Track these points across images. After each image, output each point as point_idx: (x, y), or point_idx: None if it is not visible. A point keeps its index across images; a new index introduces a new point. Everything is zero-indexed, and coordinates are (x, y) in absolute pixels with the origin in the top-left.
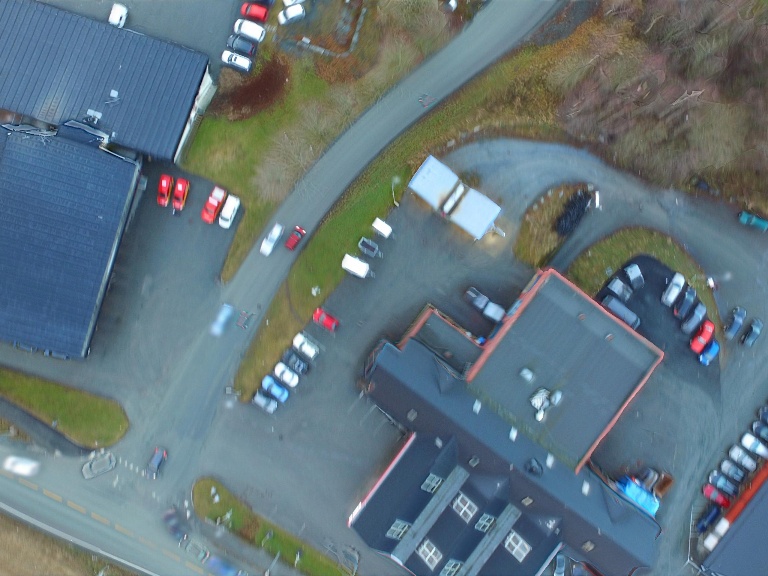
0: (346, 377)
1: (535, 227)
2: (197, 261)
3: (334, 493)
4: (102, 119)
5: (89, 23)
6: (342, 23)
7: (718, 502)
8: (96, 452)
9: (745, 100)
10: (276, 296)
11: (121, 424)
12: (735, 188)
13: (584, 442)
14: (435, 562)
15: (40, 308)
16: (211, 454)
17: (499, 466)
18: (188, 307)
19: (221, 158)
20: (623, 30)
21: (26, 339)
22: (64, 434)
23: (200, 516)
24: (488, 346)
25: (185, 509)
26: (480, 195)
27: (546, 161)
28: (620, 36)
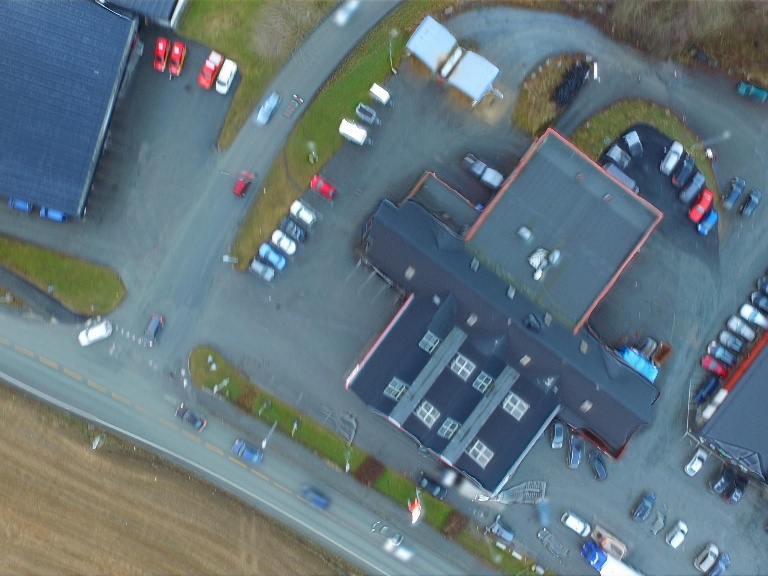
0: (344, 246)
1: (533, 95)
2: (194, 128)
3: (331, 359)
4: None
5: None
6: None
7: (716, 372)
8: (92, 320)
9: None
10: (273, 164)
11: (117, 292)
12: (734, 59)
13: (582, 303)
14: (433, 420)
15: (36, 162)
16: (208, 323)
17: (497, 322)
18: (185, 174)
19: (218, 25)
20: None
21: (22, 194)
22: (60, 301)
23: (197, 385)
24: (486, 208)
25: (182, 378)
26: (478, 56)
27: (544, 30)
28: None
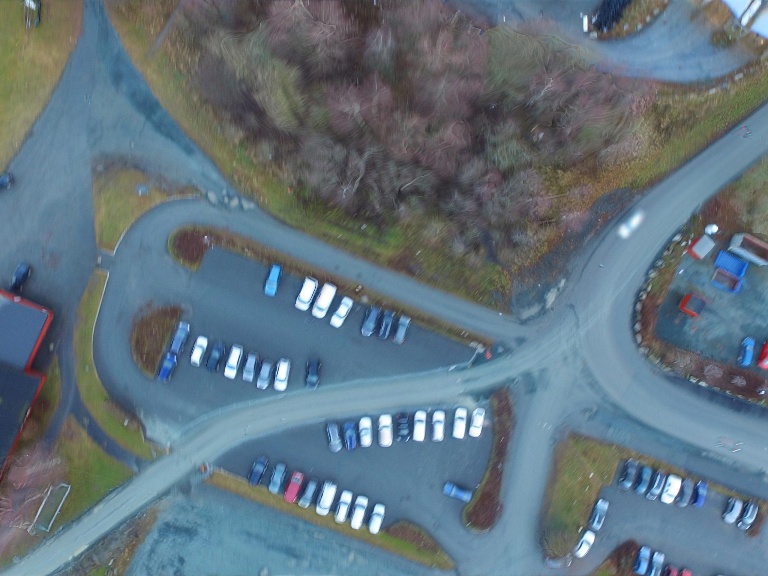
0: None
1: None
2: None
3: None
4: None
5: None
6: None
7: None
8: None
9: None
10: None
11: None
12: None
13: None
14: None
15: None
16: None
17: None
18: None
19: None
20: (547, 202)
21: None
22: None
23: None
24: None
25: None
26: (734, 8)
27: (642, 60)
28: (551, 195)
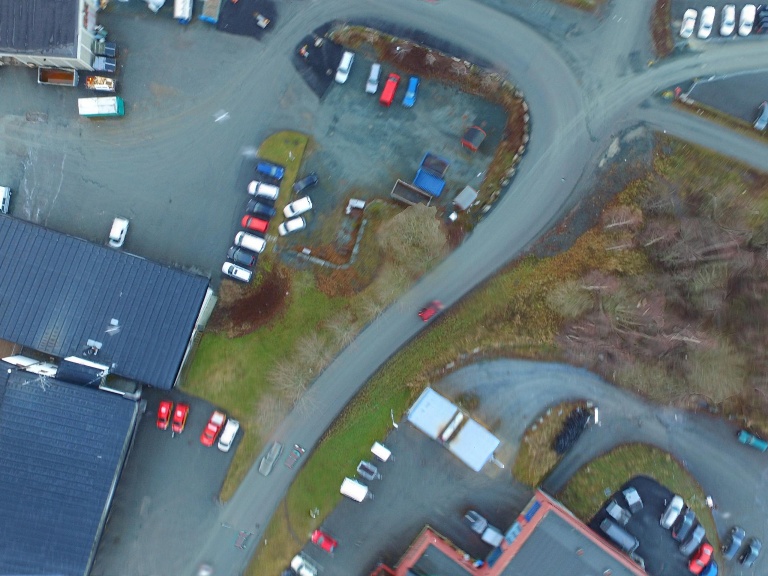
0: None
1: (534, 448)
2: (196, 483)
3: None
4: (102, 349)
5: (90, 249)
6: (342, 233)
7: None
8: None
9: (744, 339)
10: (274, 516)
11: None
12: (734, 406)
13: None
14: None
15: (38, 549)
16: None
17: None
18: (186, 528)
19: (221, 379)
20: (623, 242)
21: None
22: None
23: None
24: None
25: None
26: (479, 427)
27: (545, 380)
28: (620, 249)
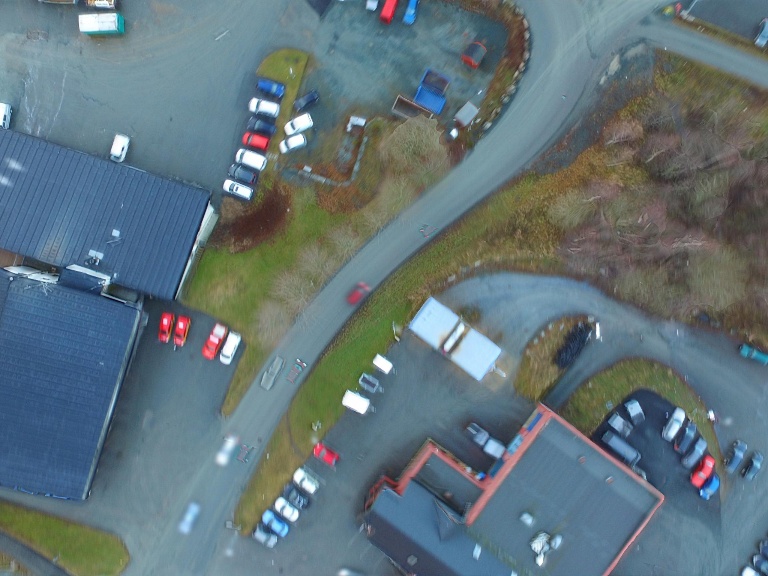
0: (346, 511)
1: (535, 362)
2: (198, 396)
3: None
4: (104, 259)
5: (91, 161)
6: (343, 151)
7: None
8: None
9: (746, 245)
10: (277, 430)
11: (121, 558)
12: (736, 320)
13: None
14: None
15: (41, 455)
16: None
17: None
18: (189, 441)
19: (222, 292)
20: (624, 159)
21: (27, 485)
22: (65, 569)
23: None
24: (488, 487)
25: None
26: (481, 336)
27: (547, 294)
28: (621, 165)
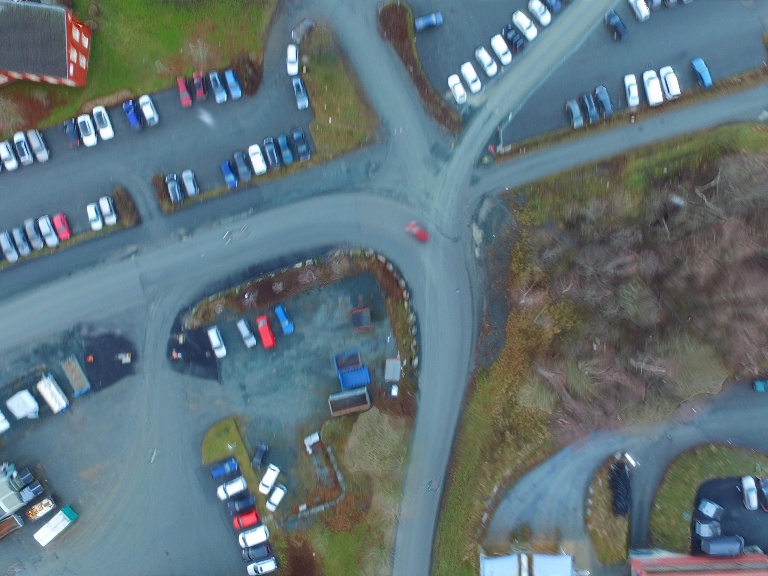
0: None
1: (602, 530)
2: None
3: None
4: None
5: None
6: (319, 470)
7: None
8: None
9: (699, 330)
10: None
11: None
12: (733, 367)
13: None
14: None
15: None
16: None
17: None
18: None
19: None
20: (543, 303)
21: None
22: None
23: None
24: None
25: None
26: (545, 558)
27: (568, 467)
28: (545, 311)
